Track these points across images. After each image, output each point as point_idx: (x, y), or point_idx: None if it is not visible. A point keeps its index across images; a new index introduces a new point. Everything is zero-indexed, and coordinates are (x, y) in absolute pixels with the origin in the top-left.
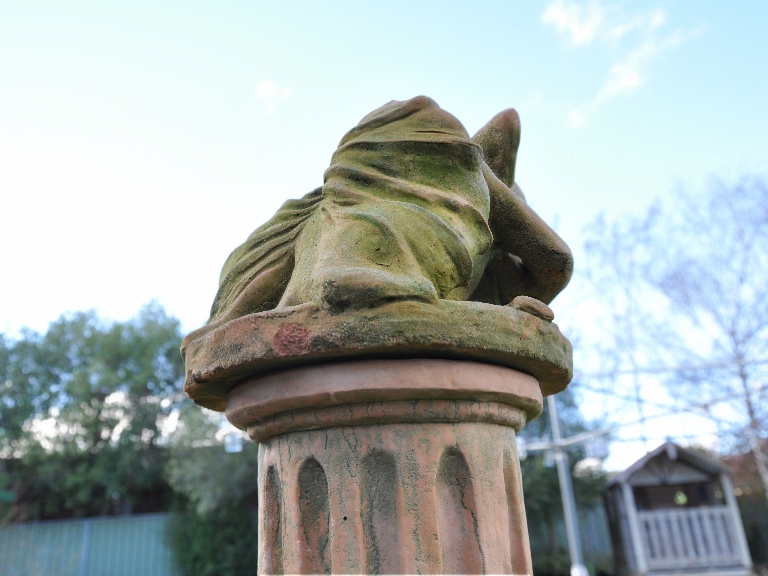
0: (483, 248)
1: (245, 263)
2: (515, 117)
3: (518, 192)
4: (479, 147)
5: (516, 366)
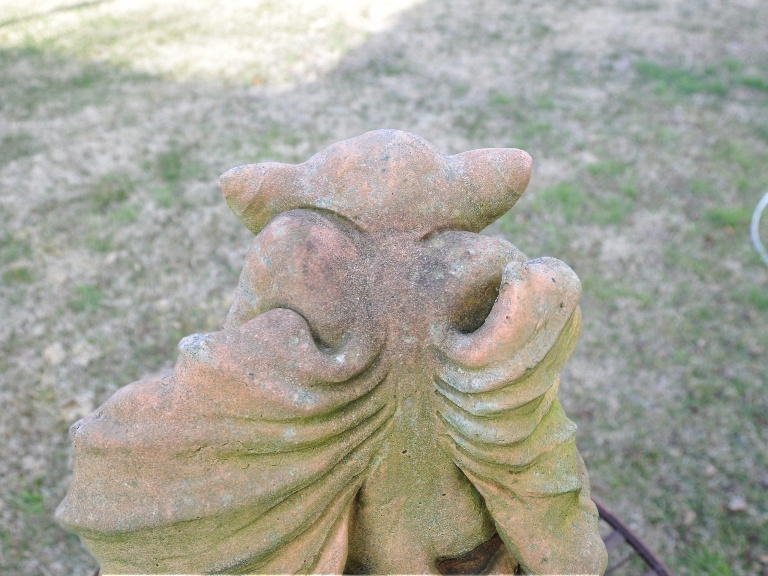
0: None
1: None
2: None
3: None
4: None
5: None
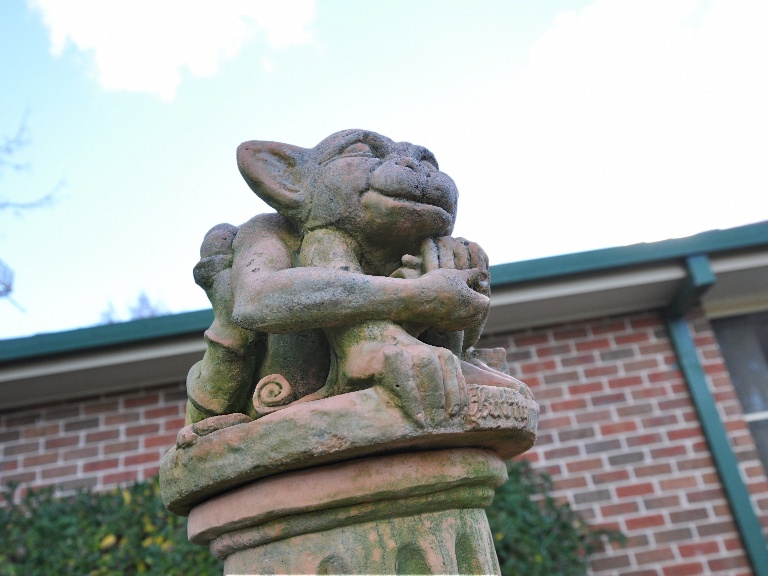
0: (231, 357)
1: None
2: None
3: (326, 180)
4: (198, 266)
5: (228, 488)
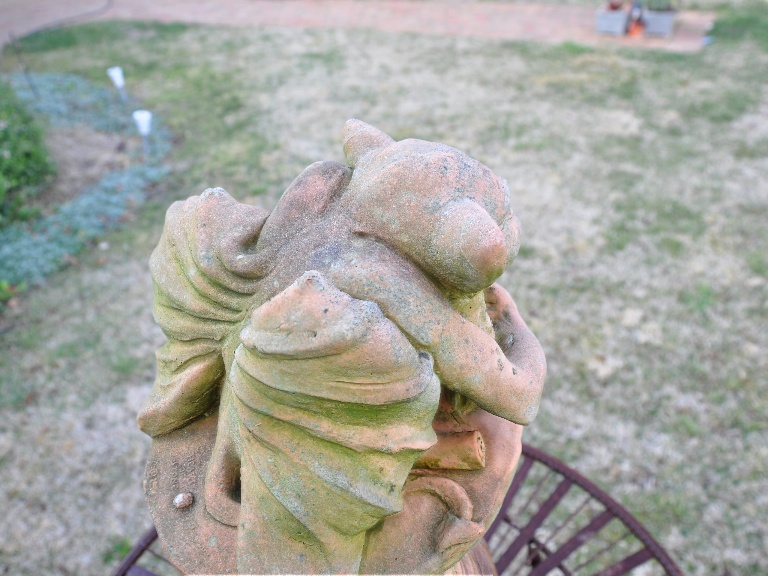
0: None
1: (171, 334)
2: (500, 253)
3: None
4: None
5: None
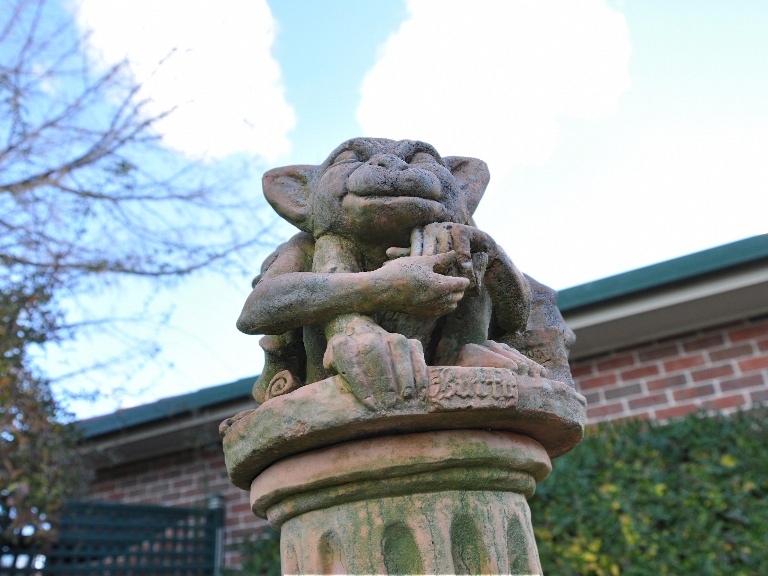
0: (273, 358)
1: None
2: None
3: None
4: None
5: (261, 471)
